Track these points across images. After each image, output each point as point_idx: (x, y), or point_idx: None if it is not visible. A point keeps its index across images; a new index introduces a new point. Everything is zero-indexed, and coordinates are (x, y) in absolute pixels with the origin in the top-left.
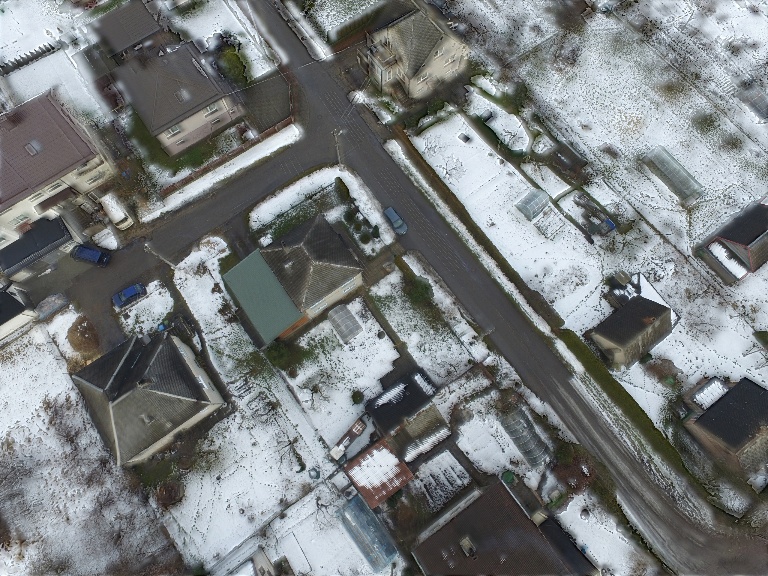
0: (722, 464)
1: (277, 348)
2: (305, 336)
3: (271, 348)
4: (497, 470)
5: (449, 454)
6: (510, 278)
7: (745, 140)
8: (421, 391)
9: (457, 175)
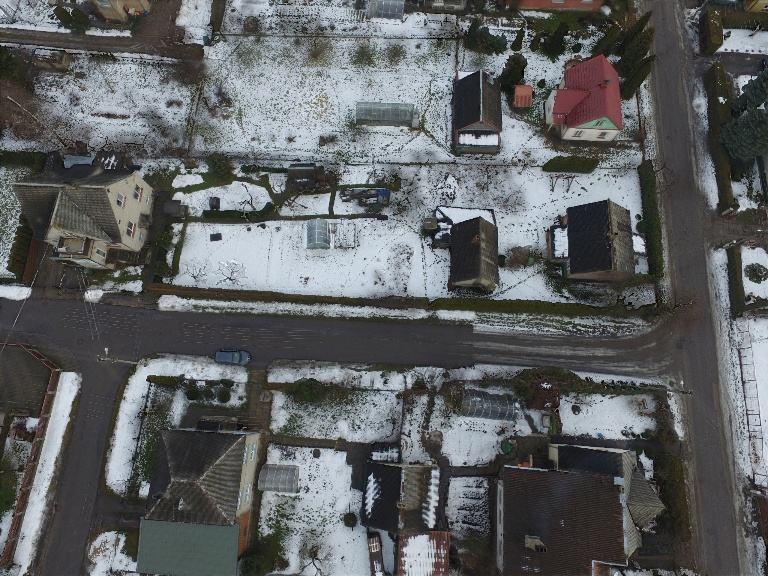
0: (612, 278)
1: (247, 568)
2: (260, 525)
3: (243, 573)
4: (495, 450)
5: (454, 479)
6: (360, 305)
7: (406, 43)
8: (387, 468)
9: (240, 275)
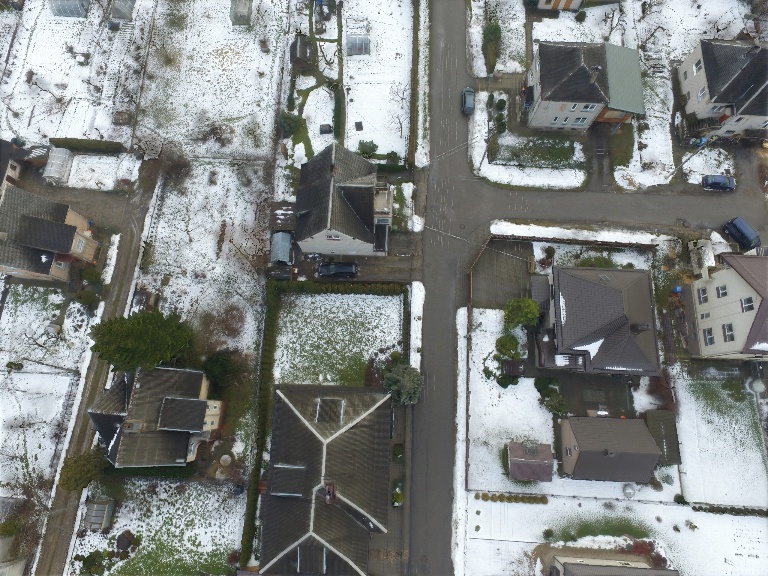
0: None
1: None
2: None
3: None
4: None
5: None
6: None
7: None
8: None
9: None
